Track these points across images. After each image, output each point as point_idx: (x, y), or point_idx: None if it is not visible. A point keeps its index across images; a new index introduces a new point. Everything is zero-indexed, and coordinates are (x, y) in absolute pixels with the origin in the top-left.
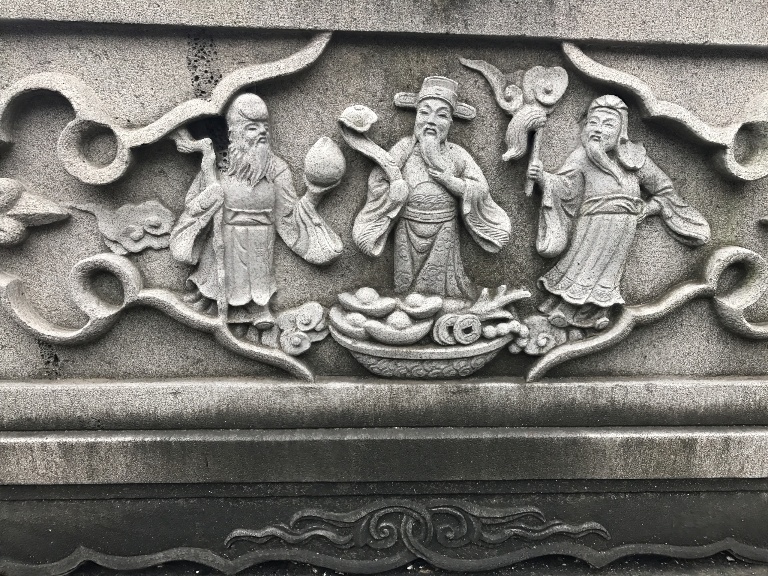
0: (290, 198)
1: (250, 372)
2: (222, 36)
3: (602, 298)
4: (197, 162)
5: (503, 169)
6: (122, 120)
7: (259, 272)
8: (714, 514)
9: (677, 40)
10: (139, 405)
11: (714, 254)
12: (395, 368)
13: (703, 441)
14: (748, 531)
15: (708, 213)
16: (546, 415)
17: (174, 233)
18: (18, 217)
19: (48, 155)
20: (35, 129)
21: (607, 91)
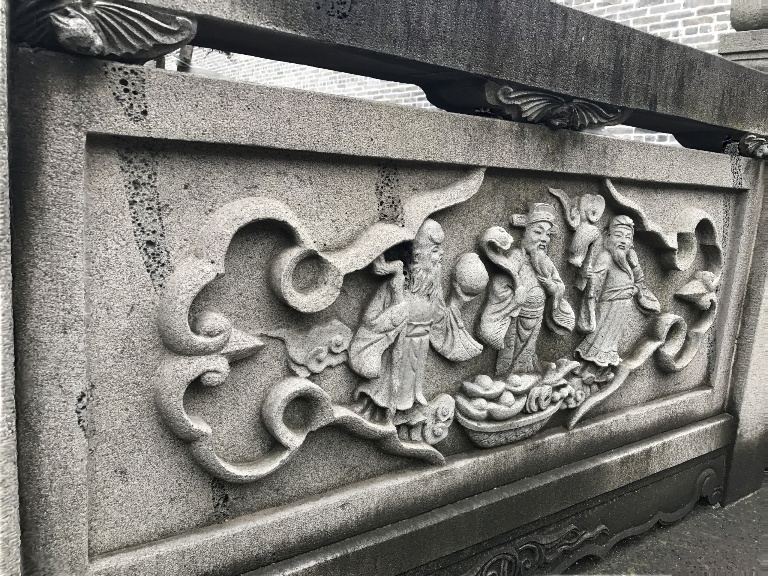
0: (442, 306)
1: (393, 468)
2: (404, 166)
3: (614, 359)
4: (373, 280)
5: (563, 270)
6: (319, 244)
7: (421, 376)
8: (655, 497)
9: (657, 179)
10: (313, 526)
11: (660, 320)
12: (498, 439)
13: (654, 449)
14: (668, 503)
15: (654, 292)
16: (578, 452)
17: (359, 350)
18: (229, 354)
19: (243, 282)
20: (233, 256)
21: (617, 211)
